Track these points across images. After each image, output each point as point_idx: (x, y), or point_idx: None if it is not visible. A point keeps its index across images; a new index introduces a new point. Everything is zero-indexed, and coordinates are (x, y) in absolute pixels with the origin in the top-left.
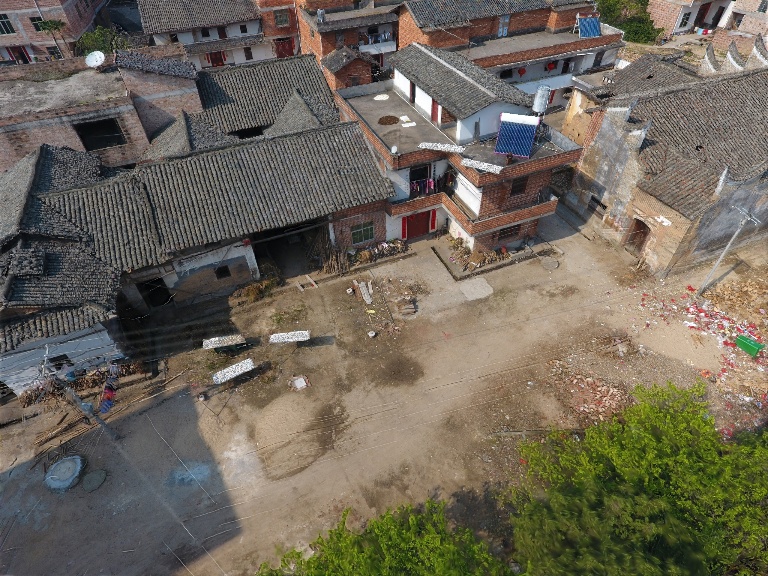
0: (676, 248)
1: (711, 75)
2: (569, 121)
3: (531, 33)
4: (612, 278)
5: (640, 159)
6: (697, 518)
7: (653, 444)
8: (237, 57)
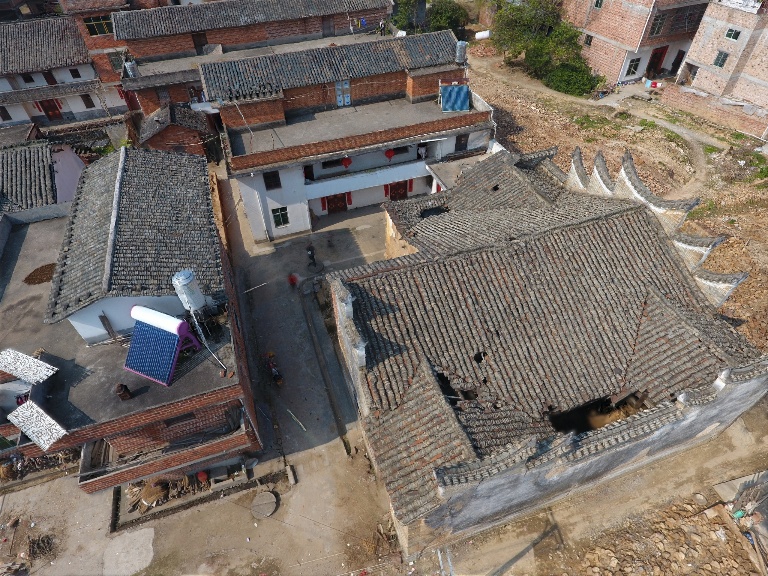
0: (406, 543)
1: (579, 191)
2: (388, 241)
3: (385, 101)
4: (341, 548)
5: (365, 384)
6: None
7: None
8: (74, 105)
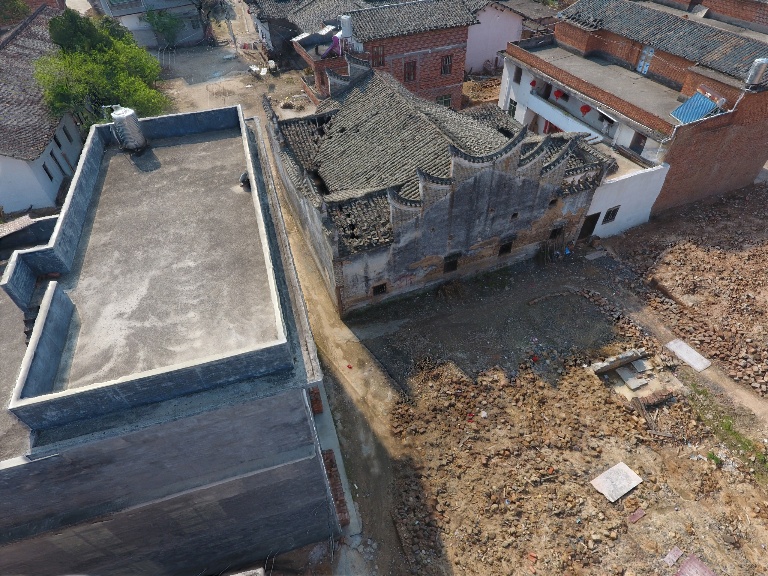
0: None
1: None
2: None
3: (671, 88)
4: None
5: (325, 100)
6: None
7: None
8: None
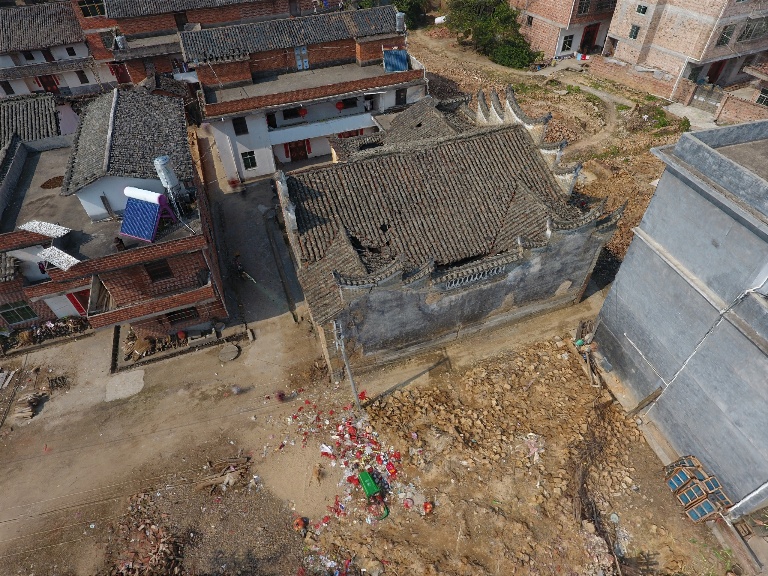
0: (327, 353)
1: (484, 125)
2: None
3: (339, 65)
4: (286, 376)
5: (298, 243)
6: None
7: None
8: (70, 81)
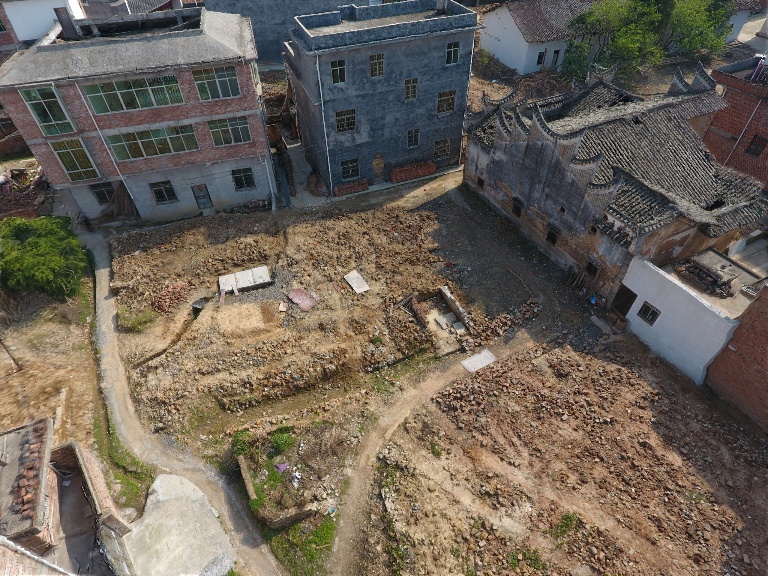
0: None
1: None
2: None
3: None
4: None
5: None
6: (636, 6)
7: None
8: None
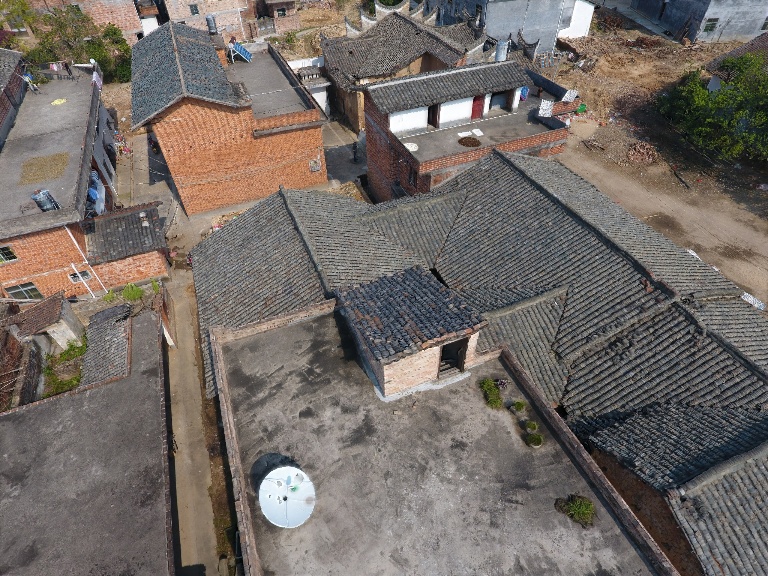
0: None
1: (358, 36)
2: None
3: None
4: None
5: None
6: None
7: (763, 86)
8: None
